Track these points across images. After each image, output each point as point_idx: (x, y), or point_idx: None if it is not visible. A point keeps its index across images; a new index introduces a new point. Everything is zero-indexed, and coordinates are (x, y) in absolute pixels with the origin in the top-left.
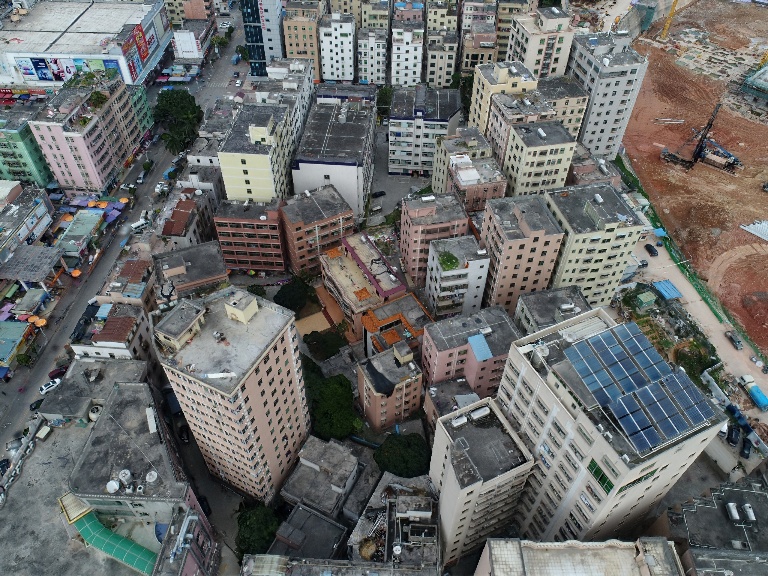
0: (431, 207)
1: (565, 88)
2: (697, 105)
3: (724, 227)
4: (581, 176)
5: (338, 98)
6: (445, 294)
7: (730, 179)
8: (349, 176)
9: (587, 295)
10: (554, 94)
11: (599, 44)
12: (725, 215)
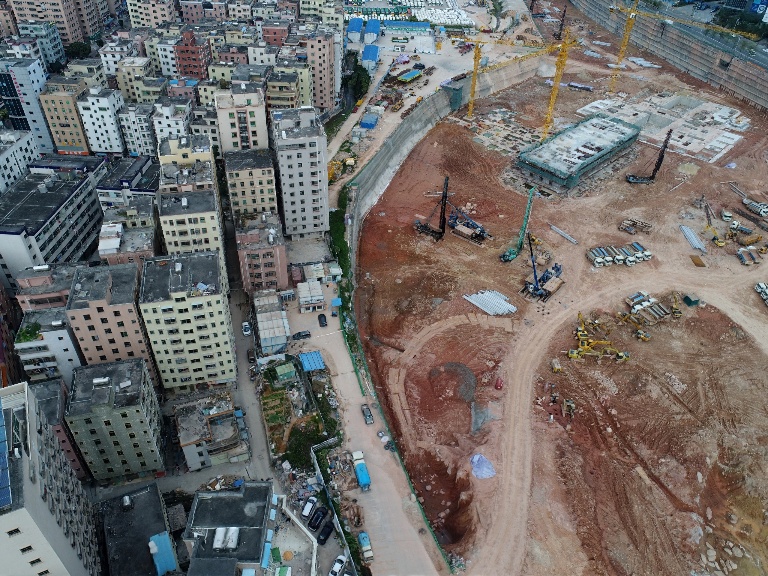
0: (42, 276)
1: (255, 160)
2: (474, 179)
3: (446, 297)
4: (246, 245)
5: (51, 168)
6: (30, 368)
7: (475, 249)
8: (17, 245)
9: (200, 367)
10: (239, 165)
11: (285, 118)
12: (451, 285)
